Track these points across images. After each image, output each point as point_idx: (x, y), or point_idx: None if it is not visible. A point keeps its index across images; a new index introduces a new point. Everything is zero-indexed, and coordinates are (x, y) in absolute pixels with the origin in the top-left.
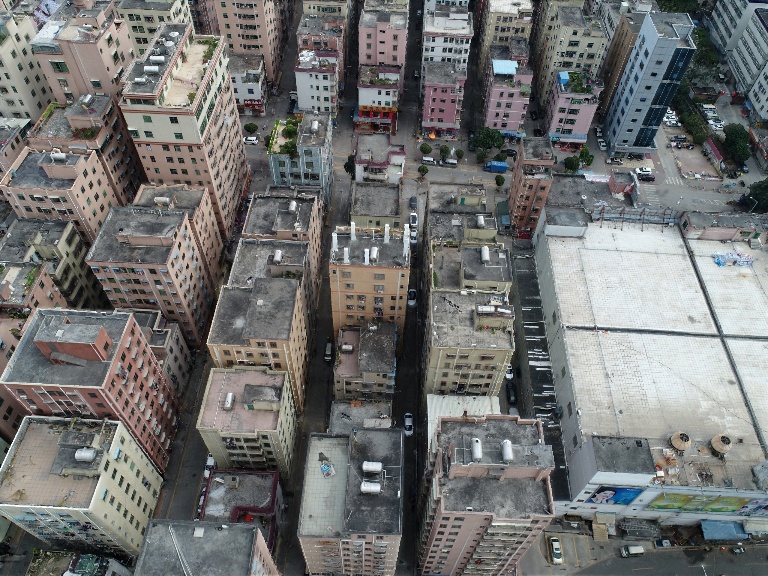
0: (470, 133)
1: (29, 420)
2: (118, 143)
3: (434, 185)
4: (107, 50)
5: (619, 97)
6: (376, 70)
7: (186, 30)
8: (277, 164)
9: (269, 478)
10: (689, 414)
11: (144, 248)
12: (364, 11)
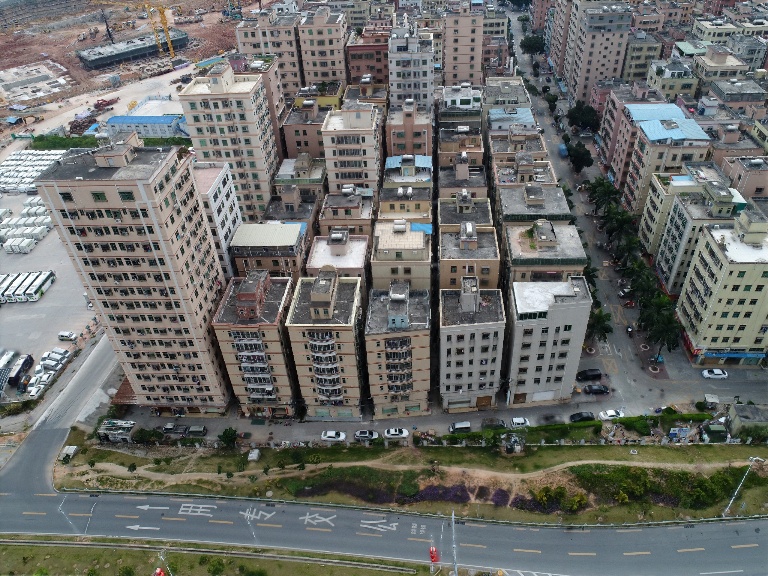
0: None
1: None
2: None
3: None
4: None
5: None
6: None
7: None
8: None
9: None
10: None
11: None
12: None
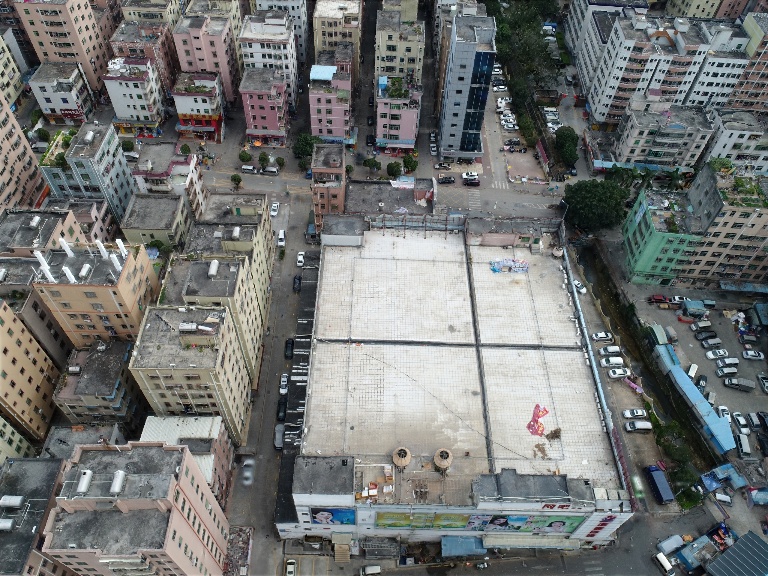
0: None
1: None
2: None
3: (216, 195)
4: None
5: (443, 101)
6: None
7: None
8: (52, 177)
9: None
10: (422, 428)
11: None
12: (184, 17)
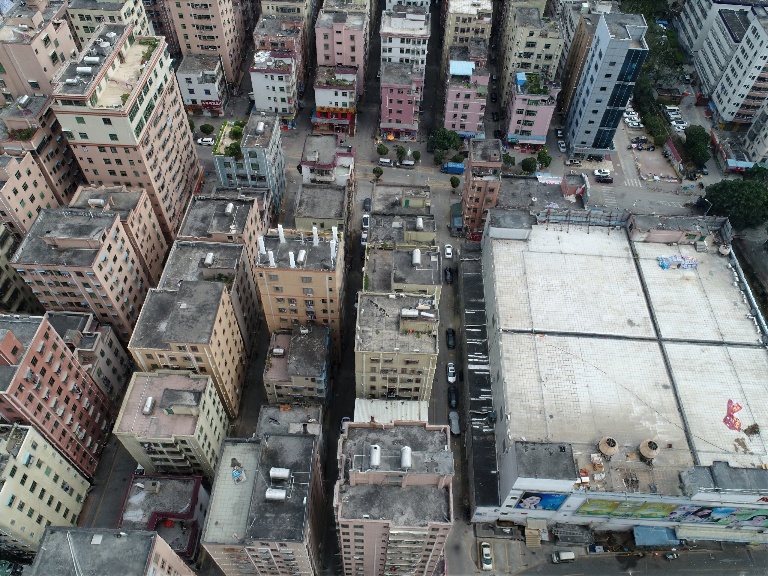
0: (429, 134)
1: None
2: (58, 144)
3: (380, 187)
4: (44, 51)
5: (578, 98)
6: (333, 71)
7: (125, 31)
8: (223, 165)
9: (191, 483)
10: (620, 419)
11: (72, 250)
12: (322, 11)
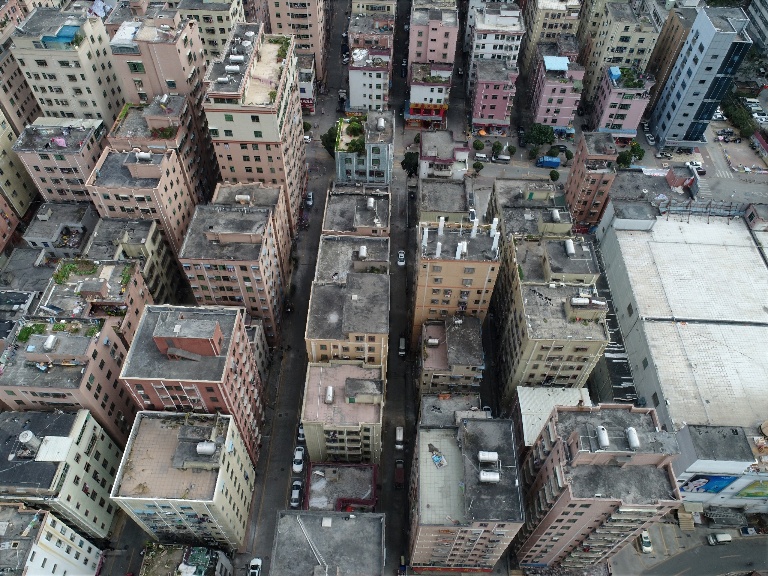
0: (519, 129)
1: (141, 415)
2: (191, 142)
3: (500, 181)
4: (183, 50)
5: (669, 92)
6: (427, 68)
7: (259, 30)
8: (344, 162)
9: (368, 470)
10: None
11: (233, 245)
12: (413, 9)
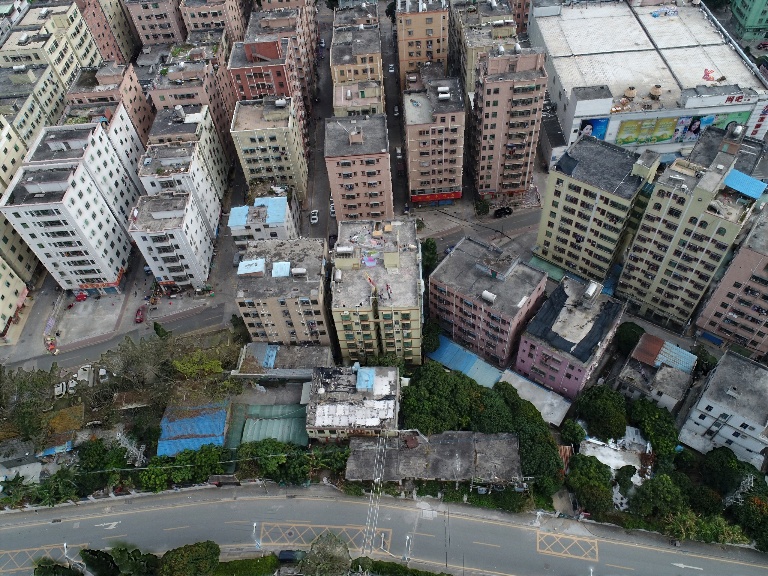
0: None
1: (239, 105)
2: None
3: None
4: None
5: None
6: None
7: None
8: None
9: None
10: (636, 84)
11: (278, 28)
12: None
